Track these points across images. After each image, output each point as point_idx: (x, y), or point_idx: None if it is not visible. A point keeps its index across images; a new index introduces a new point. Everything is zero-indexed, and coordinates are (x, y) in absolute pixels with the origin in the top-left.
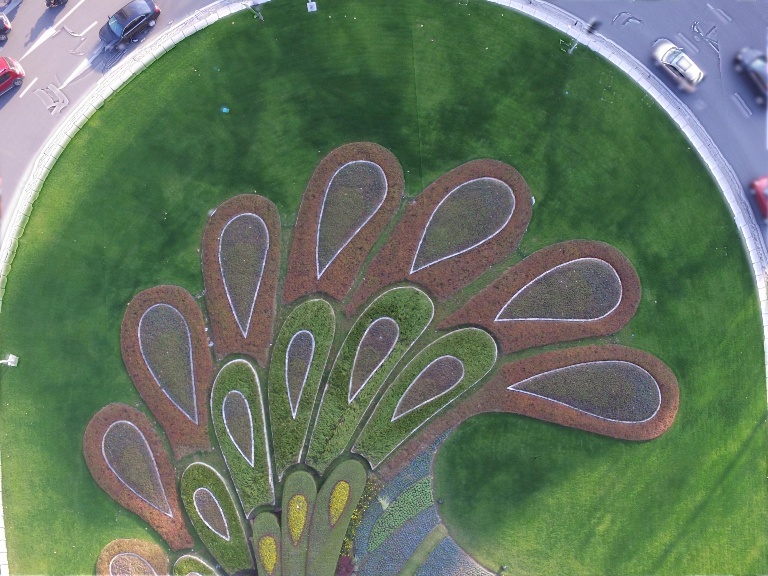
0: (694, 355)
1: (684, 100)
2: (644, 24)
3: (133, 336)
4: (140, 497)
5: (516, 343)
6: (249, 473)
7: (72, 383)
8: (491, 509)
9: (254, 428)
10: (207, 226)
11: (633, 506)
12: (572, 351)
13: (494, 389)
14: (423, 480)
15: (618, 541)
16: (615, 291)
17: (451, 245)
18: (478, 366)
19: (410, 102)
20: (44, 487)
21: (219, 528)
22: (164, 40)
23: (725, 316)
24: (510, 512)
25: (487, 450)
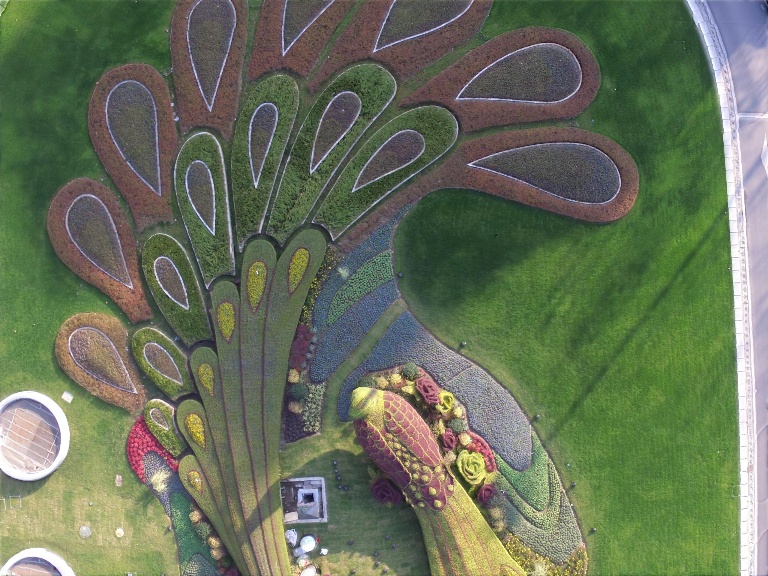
0: (654, 143)
1: None
2: None
3: (100, 112)
4: (101, 270)
5: (477, 120)
6: (210, 241)
7: (39, 161)
8: (451, 285)
9: (216, 196)
10: (177, 7)
11: (593, 288)
12: (532, 131)
13: (455, 164)
14: (383, 253)
15: (579, 323)
16: (575, 75)
17: (414, 25)
18: (439, 140)
19: None
20: (7, 265)
21: (179, 297)
22: None
23: (684, 107)
24: (470, 289)
25: (447, 226)
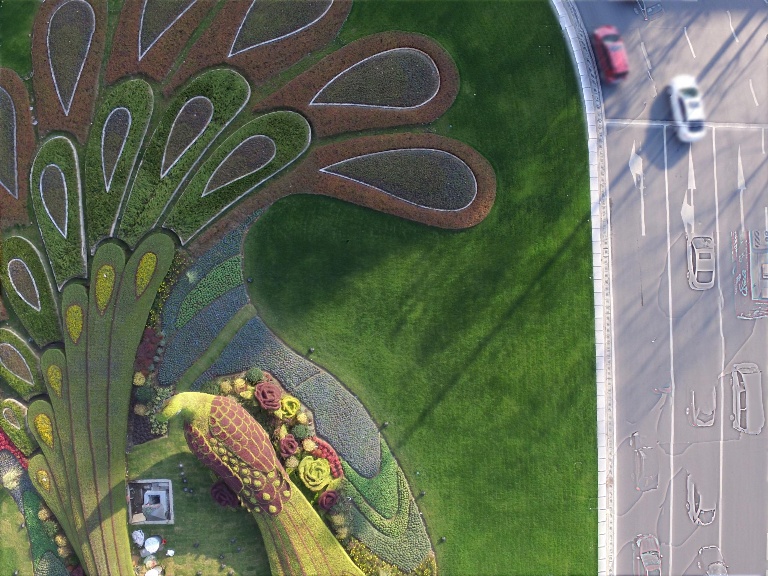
0: (513, 149)
1: None
2: None
3: None
4: None
5: (330, 126)
6: (62, 244)
7: None
8: (301, 291)
9: (68, 200)
10: (39, 12)
11: (446, 296)
12: (386, 136)
13: (306, 170)
14: (233, 258)
15: (430, 330)
16: (432, 81)
17: (269, 30)
18: (290, 146)
19: None
20: None
21: (31, 298)
22: None
23: (547, 113)
24: (320, 295)
25: (298, 232)
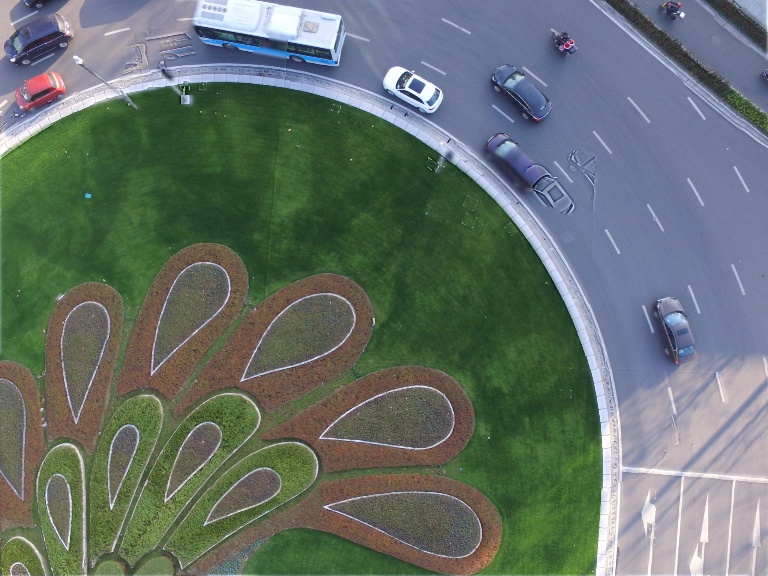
0: (523, 496)
1: (550, 231)
2: (520, 148)
3: None
4: None
5: (337, 464)
6: (64, 555)
7: None
8: None
9: (72, 513)
10: (55, 309)
11: None
12: (394, 478)
13: (310, 507)
14: None
15: None
16: (446, 423)
17: (284, 358)
18: (296, 482)
19: (266, 207)
20: None
21: None
22: (42, 118)
23: (561, 460)
24: None
25: (298, 565)
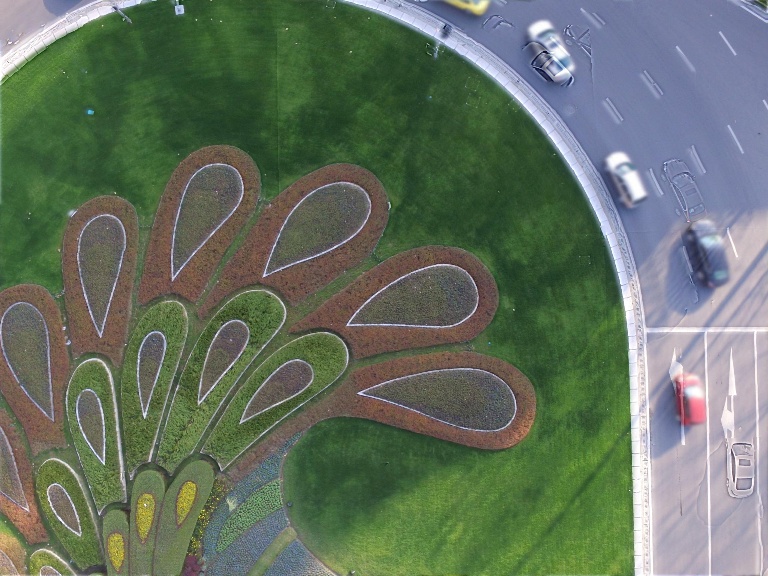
0: (553, 364)
1: (553, 105)
2: (515, 27)
3: None
4: None
5: (367, 348)
6: (100, 471)
7: None
8: (340, 514)
9: (106, 426)
10: (68, 226)
11: (486, 515)
12: (424, 358)
13: (344, 394)
14: (272, 483)
15: (470, 550)
16: (471, 298)
17: (304, 249)
18: (327, 371)
19: (271, 105)
20: None
21: (71, 524)
22: (36, 42)
23: (587, 326)
24: (359, 517)
25: (337, 455)
